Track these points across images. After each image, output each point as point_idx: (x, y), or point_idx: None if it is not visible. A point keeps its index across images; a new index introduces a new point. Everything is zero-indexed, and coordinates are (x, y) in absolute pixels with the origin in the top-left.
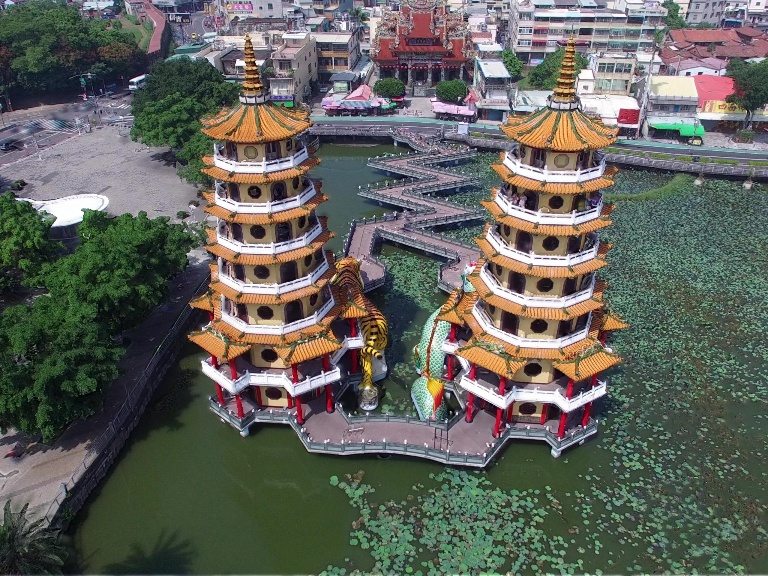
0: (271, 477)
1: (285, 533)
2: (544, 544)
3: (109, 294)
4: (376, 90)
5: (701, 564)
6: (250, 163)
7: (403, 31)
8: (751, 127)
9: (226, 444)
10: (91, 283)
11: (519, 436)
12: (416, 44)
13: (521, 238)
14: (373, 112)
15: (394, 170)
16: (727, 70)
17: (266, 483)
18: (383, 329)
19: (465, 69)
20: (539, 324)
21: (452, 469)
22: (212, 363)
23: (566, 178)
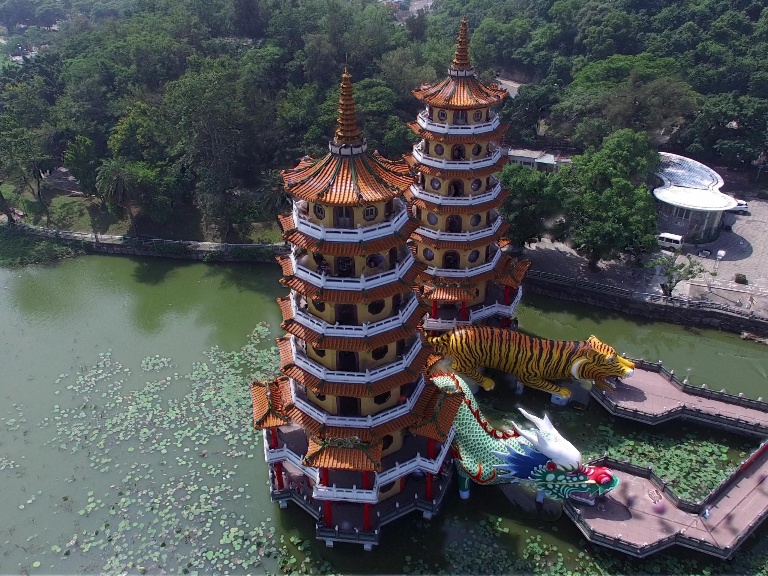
0: None
1: None
2: (208, 431)
3: None
4: None
5: (114, 522)
6: None
7: None
8: None
9: None
10: None
11: None
12: None
13: None
14: None
15: None
16: None
17: None
18: None
19: None
20: None
21: None
22: None
23: None
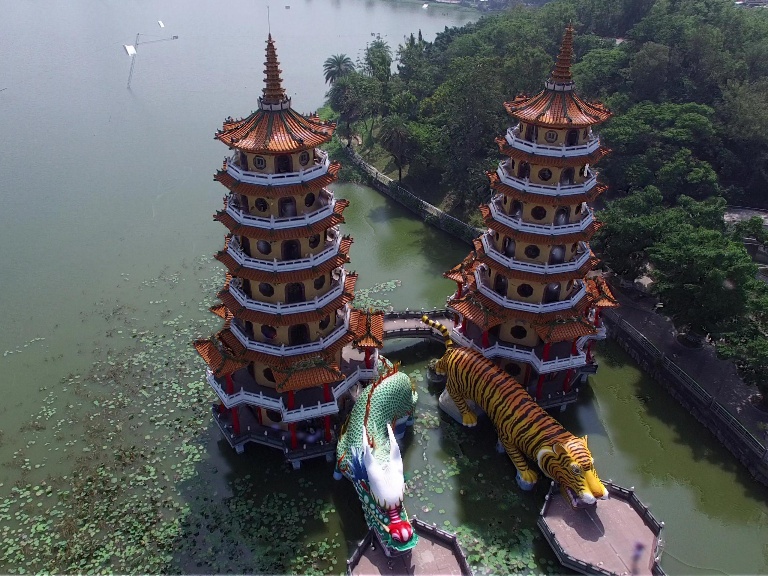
0: None
1: None
2: None
3: None
4: None
5: None
6: None
7: None
8: None
9: None
10: None
11: None
12: None
13: None
14: None
15: None
16: None
17: None
18: None
19: None
20: None
21: None
22: None
23: None
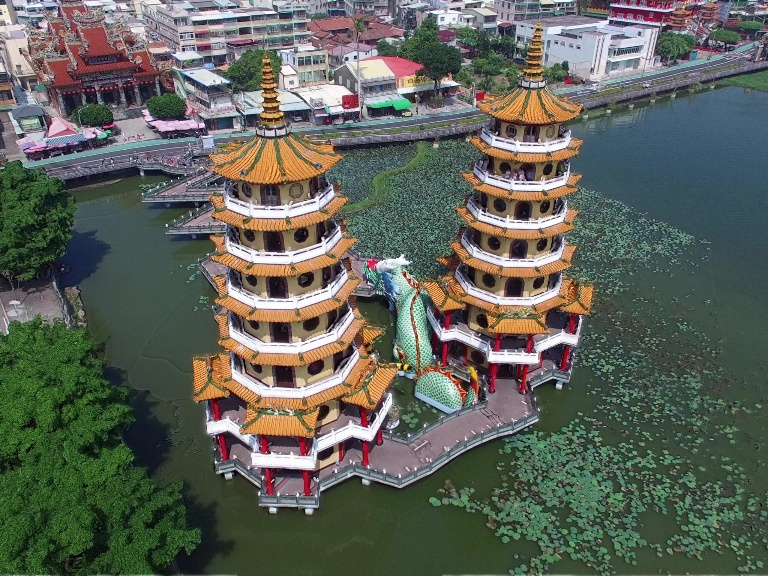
0: (332, 544)
1: (443, 572)
2: (620, 454)
3: (95, 431)
4: (80, 120)
5: (703, 411)
6: (303, 202)
7: (80, 50)
8: (441, 94)
9: (288, 535)
10: (59, 428)
11: (536, 384)
12: (97, 63)
13: (520, 209)
14: (87, 145)
15: (179, 199)
16: (379, 51)
17: (328, 554)
18: (372, 345)
19: (160, 82)
20: (538, 280)
21: (508, 438)
22: (264, 451)
23: (560, 146)
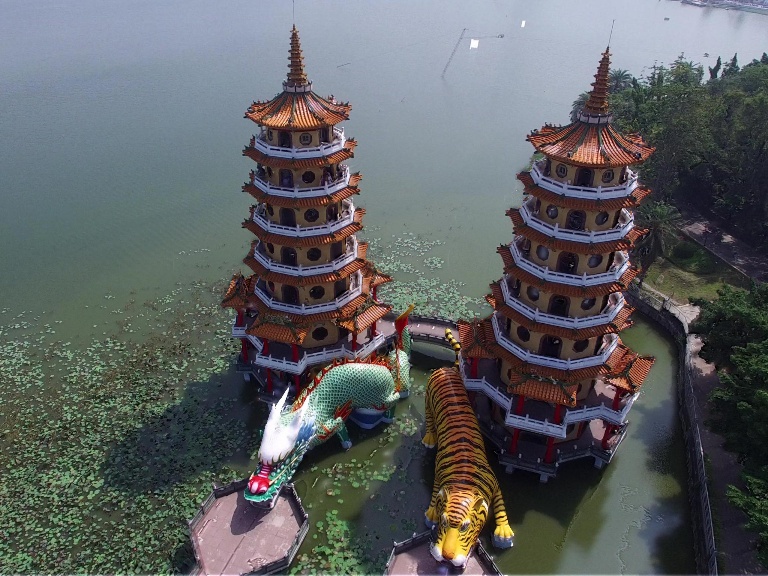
0: None
1: None
2: None
3: None
4: None
5: None
6: None
7: None
8: None
9: None
10: None
11: None
12: None
13: None
14: None
15: None
16: None
17: None
18: None
19: None
20: None
21: None
22: None
23: None
